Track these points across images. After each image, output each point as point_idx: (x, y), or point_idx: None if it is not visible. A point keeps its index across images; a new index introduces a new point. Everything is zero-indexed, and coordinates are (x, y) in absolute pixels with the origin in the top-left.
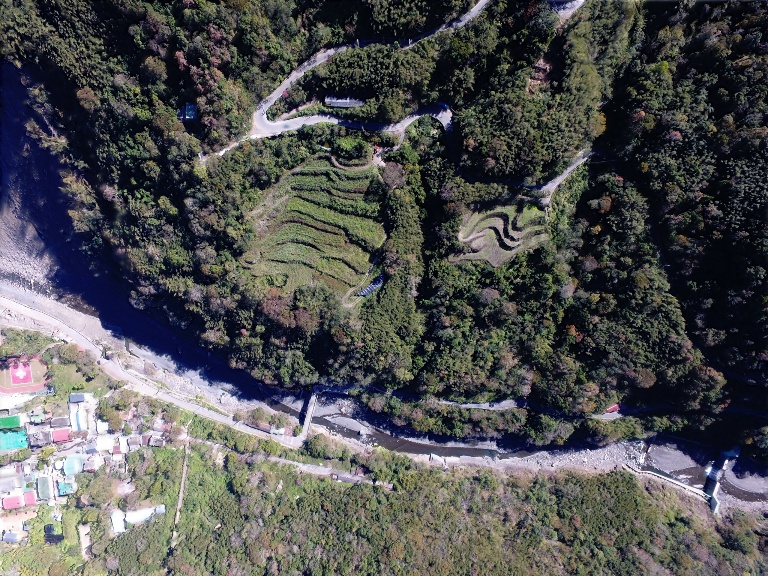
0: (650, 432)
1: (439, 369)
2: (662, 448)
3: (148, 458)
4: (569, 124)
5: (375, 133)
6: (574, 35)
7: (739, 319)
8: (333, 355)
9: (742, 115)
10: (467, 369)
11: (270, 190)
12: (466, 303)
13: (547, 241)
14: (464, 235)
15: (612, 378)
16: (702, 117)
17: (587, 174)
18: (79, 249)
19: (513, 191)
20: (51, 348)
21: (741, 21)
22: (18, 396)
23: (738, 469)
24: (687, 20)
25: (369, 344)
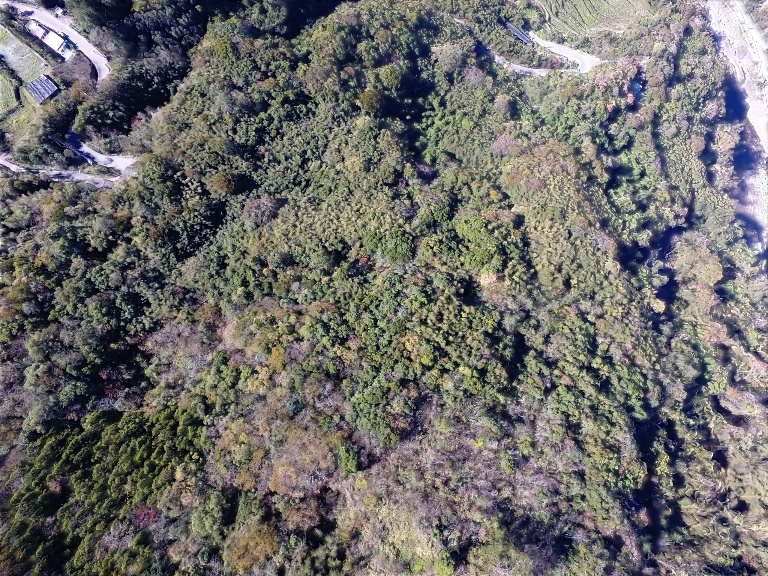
0: None
1: None
2: None
3: None
4: None
5: None
6: None
7: None
8: None
9: None
10: None
11: None
12: None
13: None
14: None
15: None
16: None
17: None
18: None
19: None
20: None
21: None
22: None
23: None
24: None
25: None
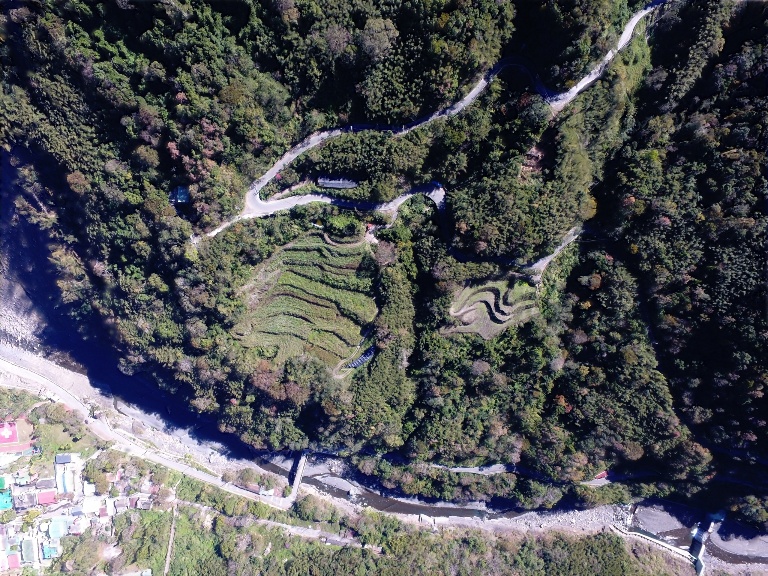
0: (637, 498)
1: (429, 437)
2: (649, 509)
3: (135, 522)
4: (560, 209)
5: (368, 212)
6: (566, 127)
7: (725, 400)
8: (323, 423)
9: (730, 204)
10: (457, 437)
11: (262, 265)
12: (457, 374)
13: (538, 314)
14: (455, 309)
15: (600, 449)
16: (691, 204)
17: (578, 250)
18: (68, 314)
19: (504, 268)
20: (38, 408)
21: (729, 114)
22: (3, 456)
23: (723, 531)
24: (677, 109)
25: (359, 415)
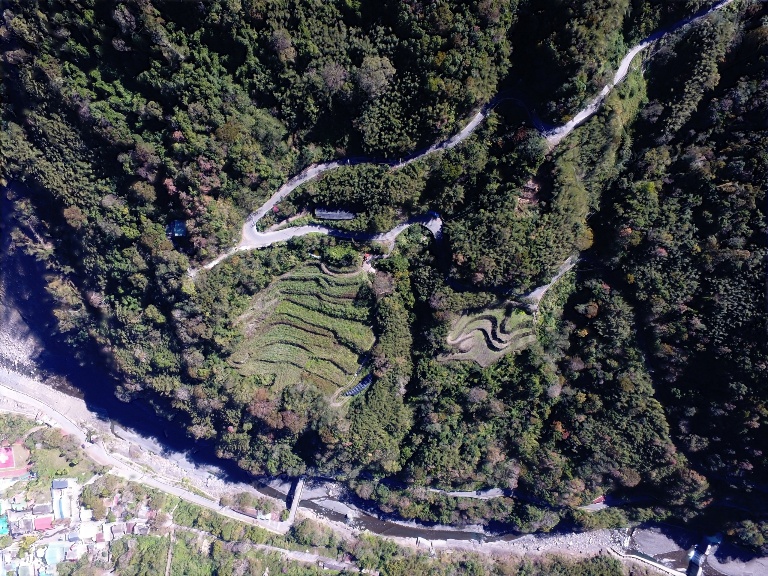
0: (634, 522)
1: (427, 463)
2: (646, 532)
3: (132, 548)
4: (557, 241)
5: (365, 243)
6: (562, 161)
7: (721, 429)
8: (321, 450)
9: (725, 235)
10: (454, 464)
11: (259, 294)
12: (454, 401)
13: (535, 342)
14: (453, 337)
15: (597, 475)
16: (687, 236)
17: (574, 278)
18: (64, 341)
19: (501, 297)
20: (34, 433)
21: (725, 148)
22: None
23: (720, 554)
24: (673, 142)
25: (357, 443)
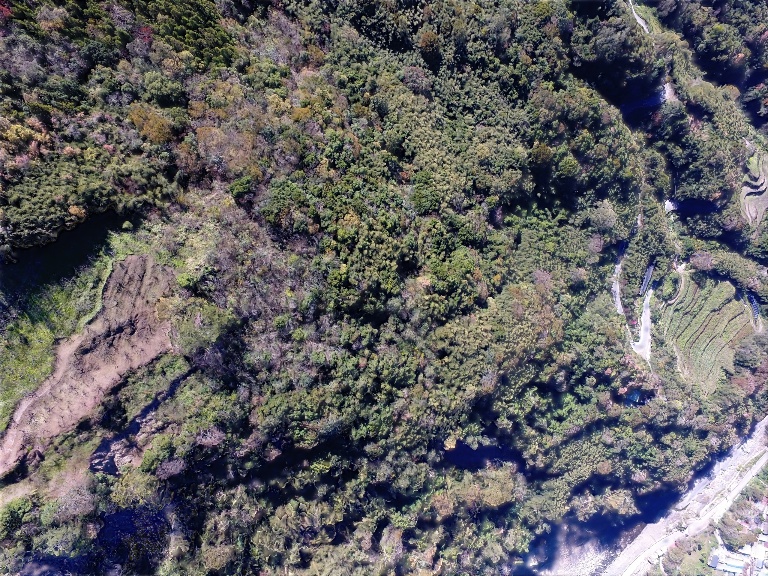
0: None
1: None
2: None
3: None
4: None
5: (669, 264)
6: None
7: None
8: None
9: None
10: None
11: None
12: None
13: None
14: None
15: None
16: (764, 11)
17: None
18: None
19: None
20: (668, 567)
21: None
22: None
23: None
24: None
25: None
